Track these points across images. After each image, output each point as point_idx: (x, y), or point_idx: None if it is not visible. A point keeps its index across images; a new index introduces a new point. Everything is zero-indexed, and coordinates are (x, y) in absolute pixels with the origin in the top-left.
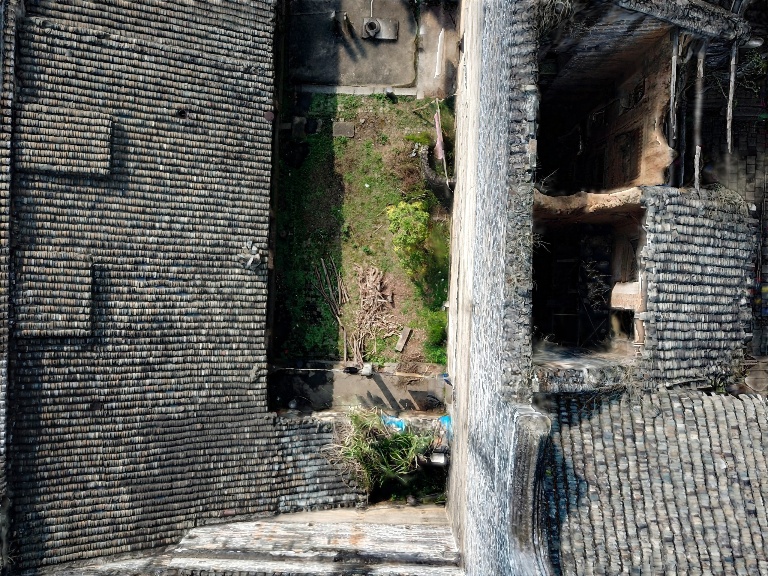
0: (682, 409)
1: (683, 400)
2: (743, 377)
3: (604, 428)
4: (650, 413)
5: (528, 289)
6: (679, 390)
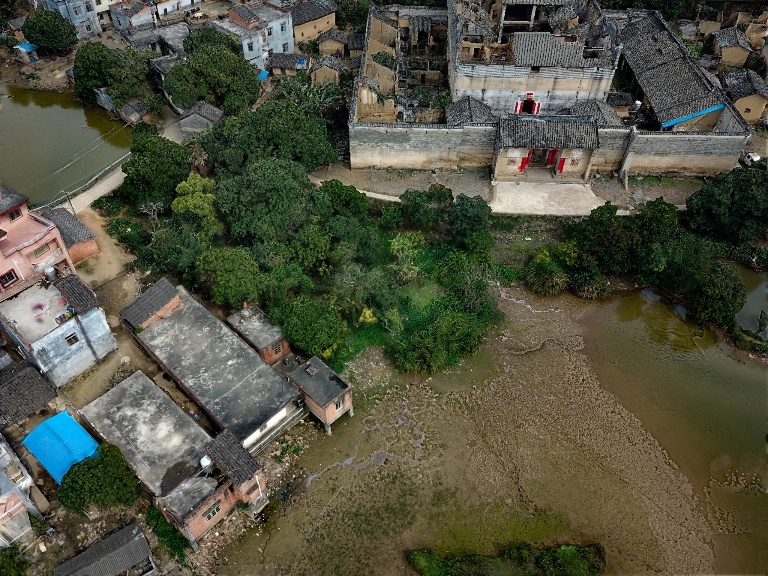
0: (566, 2)
1: (566, 3)
2: (550, 13)
3: (577, 0)
4: (571, 2)
5: (594, 1)
6: (565, 5)
